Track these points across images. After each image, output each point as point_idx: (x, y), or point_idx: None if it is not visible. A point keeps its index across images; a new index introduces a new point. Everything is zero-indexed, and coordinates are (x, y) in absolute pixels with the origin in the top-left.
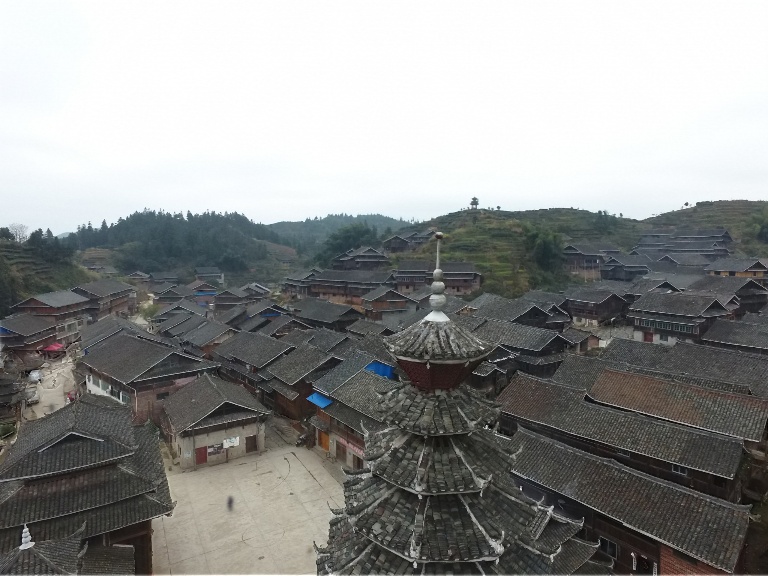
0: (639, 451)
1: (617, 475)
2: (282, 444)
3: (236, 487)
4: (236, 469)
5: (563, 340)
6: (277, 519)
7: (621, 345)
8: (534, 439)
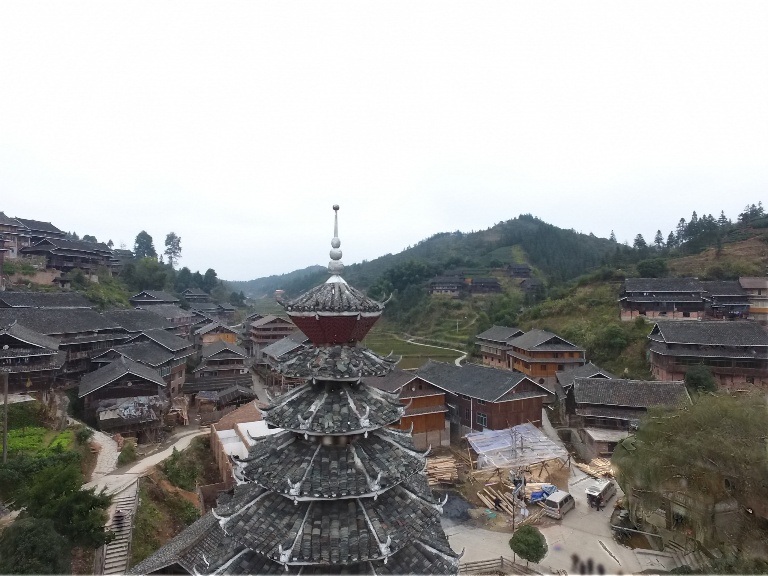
0: None
1: None
2: None
3: None
4: None
5: None
6: None
7: None
8: None
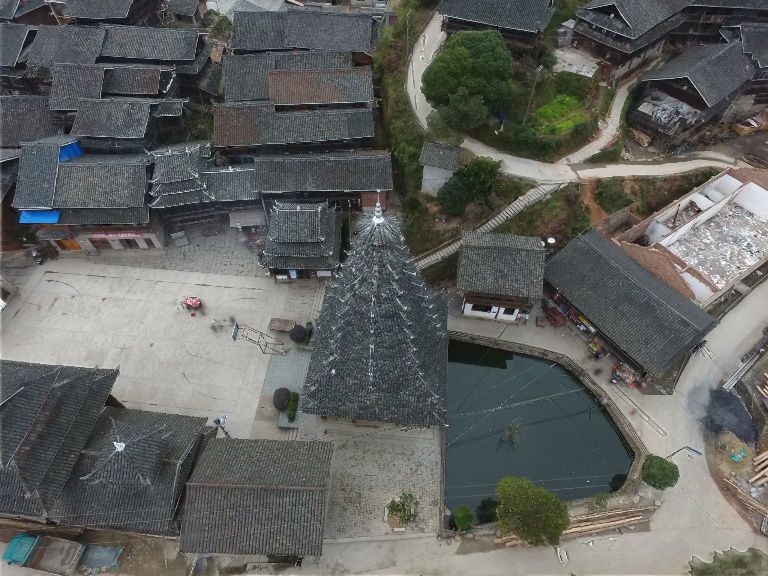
0: (327, 139)
1: (329, 165)
2: (17, 272)
3: (49, 330)
4: (20, 320)
5: None
6: (123, 320)
7: (244, 19)
8: (270, 163)
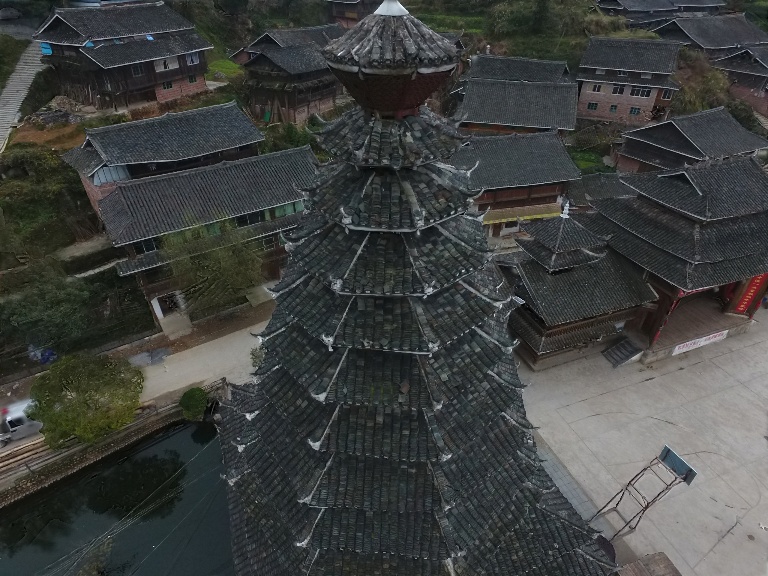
0: None
1: None
2: None
3: None
4: None
5: None
6: None
7: None
8: None
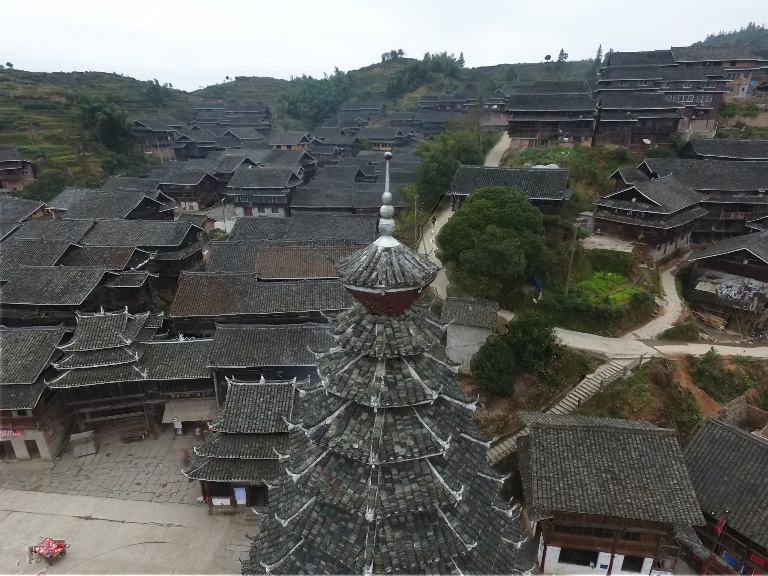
0: (317, 309)
1: (316, 333)
2: None
3: None
4: None
5: (196, 229)
6: None
7: (246, 224)
8: (236, 331)
